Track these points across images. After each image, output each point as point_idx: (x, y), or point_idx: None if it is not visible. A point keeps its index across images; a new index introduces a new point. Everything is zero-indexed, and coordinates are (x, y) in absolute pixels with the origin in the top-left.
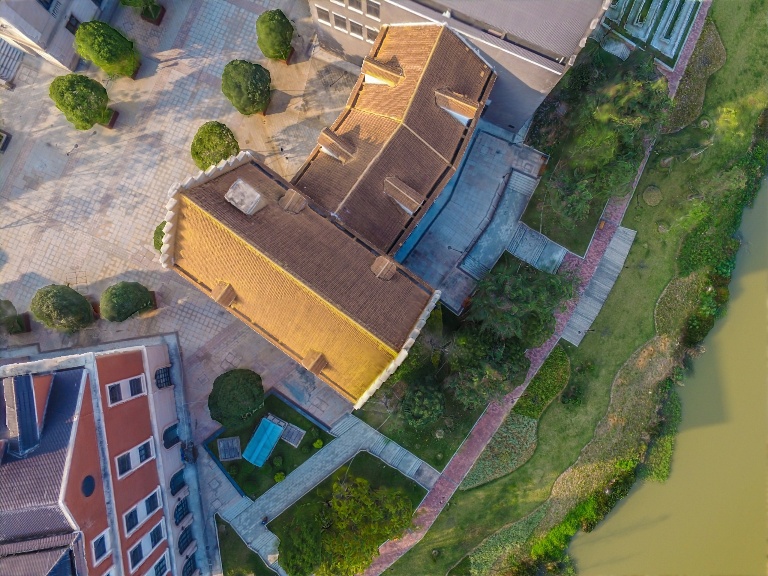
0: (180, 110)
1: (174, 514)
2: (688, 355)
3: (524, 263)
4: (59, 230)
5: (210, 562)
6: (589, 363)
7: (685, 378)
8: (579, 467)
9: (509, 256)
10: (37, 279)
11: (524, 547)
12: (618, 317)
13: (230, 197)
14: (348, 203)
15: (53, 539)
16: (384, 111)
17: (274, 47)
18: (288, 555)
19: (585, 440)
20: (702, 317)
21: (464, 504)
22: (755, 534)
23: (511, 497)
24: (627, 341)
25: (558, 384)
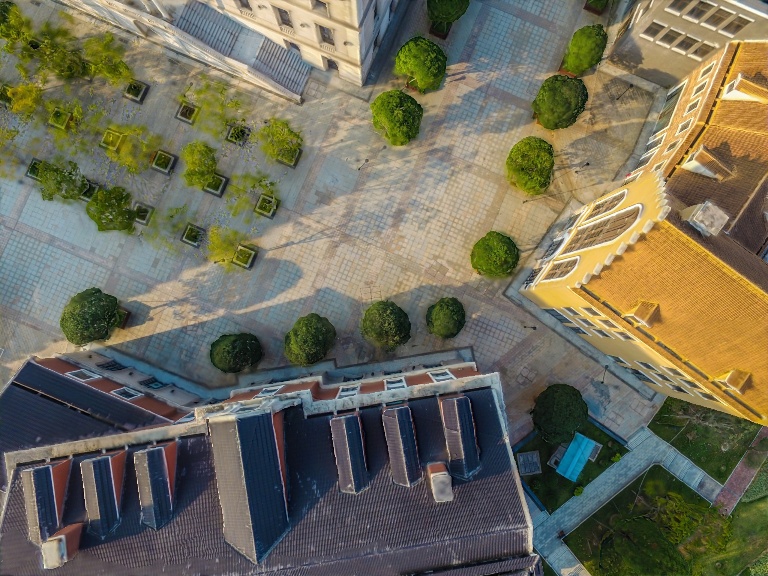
0: (469, 124)
1: None
2: None
3: None
4: (353, 245)
5: None
6: None
7: None
8: None
9: None
10: (332, 294)
11: None
12: None
13: (700, 220)
14: (739, 221)
15: (514, 562)
16: (760, 128)
17: (591, 62)
18: (656, 572)
19: None
20: None
21: (746, 516)
22: None
23: None
24: None
25: None
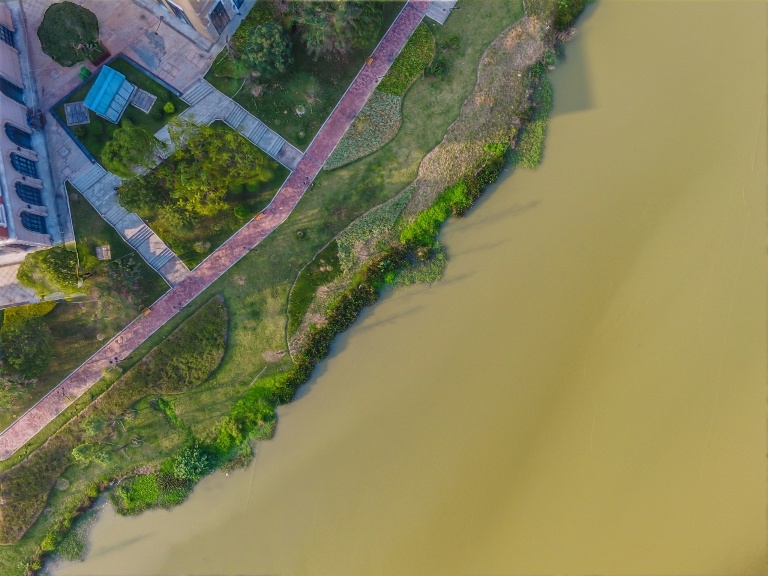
0: None
1: (10, 155)
2: (559, 40)
3: None
4: None
5: (62, 230)
6: None
7: (556, 63)
8: (446, 147)
9: None
10: None
11: (393, 232)
12: None
13: None
14: None
15: None
16: None
17: None
18: None
19: (451, 118)
20: None
21: (328, 184)
22: (628, 218)
23: (376, 177)
24: (494, 20)
25: (422, 61)
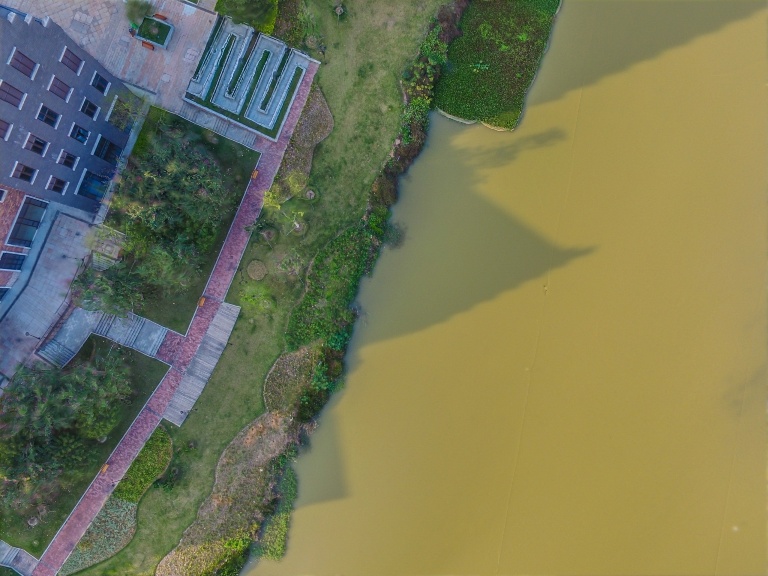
0: None
1: None
2: (304, 430)
3: (117, 345)
4: None
5: None
6: (192, 443)
7: (301, 453)
8: (182, 549)
9: (98, 339)
10: None
11: None
12: (223, 395)
13: None
14: None
15: None
16: None
17: None
18: None
19: (187, 522)
20: (312, 392)
21: None
22: None
23: None
24: (233, 419)
25: (158, 466)
